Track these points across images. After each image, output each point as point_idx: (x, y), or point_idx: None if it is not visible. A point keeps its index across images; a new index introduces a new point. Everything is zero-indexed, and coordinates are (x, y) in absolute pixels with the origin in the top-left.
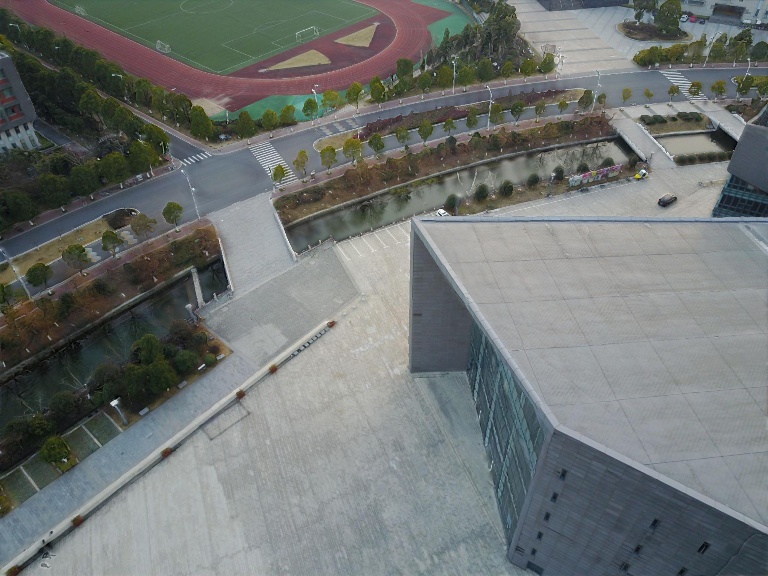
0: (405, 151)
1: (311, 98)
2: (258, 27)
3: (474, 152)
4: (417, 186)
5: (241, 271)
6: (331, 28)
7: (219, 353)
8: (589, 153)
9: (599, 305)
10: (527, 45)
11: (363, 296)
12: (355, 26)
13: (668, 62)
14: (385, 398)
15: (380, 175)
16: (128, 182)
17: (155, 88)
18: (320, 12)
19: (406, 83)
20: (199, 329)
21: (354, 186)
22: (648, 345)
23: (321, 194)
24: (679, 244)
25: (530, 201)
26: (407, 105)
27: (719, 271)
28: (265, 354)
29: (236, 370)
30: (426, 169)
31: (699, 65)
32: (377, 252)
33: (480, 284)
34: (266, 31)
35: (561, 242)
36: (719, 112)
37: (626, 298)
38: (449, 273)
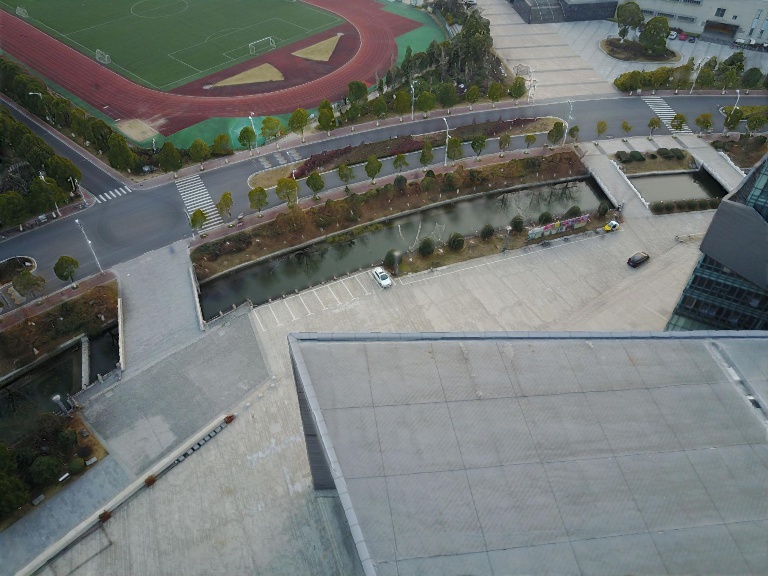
0: (350, 190)
1: (248, 126)
2: (211, 35)
3: (427, 193)
4: (359, 233)
5: (138, 343)
6: (290, 38)
7: (91, 456)
8: (558, 193)
9: (510, 479)
10: (500, 64)
11: (273, 380)
12: (316, 36)
13: (651, 87)
14: (278, 525)
15: (317, 220)
16: (29, 223)
17: (74, 111)
18: (281, 19)
19: (358, 109)
20: (73, 421)
21: (286, 233)
22: (567, 549)
23: (247, 243)
24: (626, 374)
25: (483, 257)
26: (360, 133)
27: (674, 417)
28: (146, 458)
29: (107, 480)
30: (371, 213)
31: (685, 91)
32: (299, 321)
33: (356, 445)
34: (219, 40)
35: (475, 373)
36: (703, 149)
37: (547, 466)
38: (318, 427)
